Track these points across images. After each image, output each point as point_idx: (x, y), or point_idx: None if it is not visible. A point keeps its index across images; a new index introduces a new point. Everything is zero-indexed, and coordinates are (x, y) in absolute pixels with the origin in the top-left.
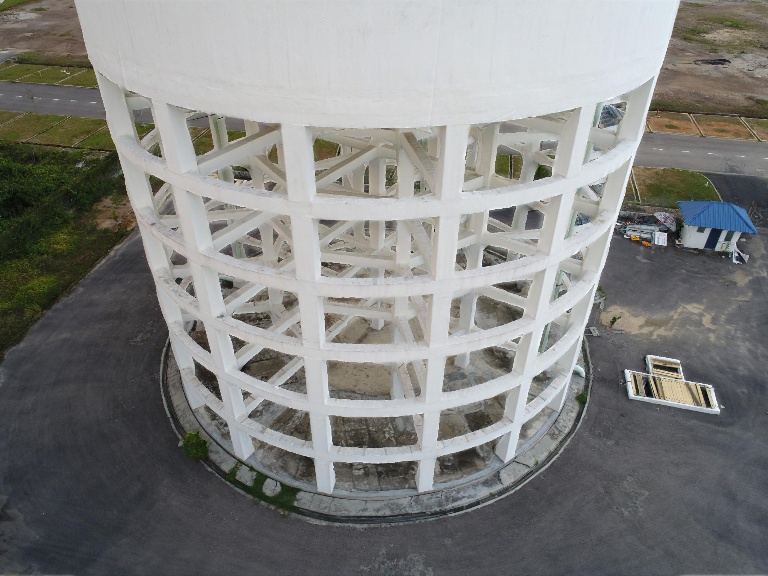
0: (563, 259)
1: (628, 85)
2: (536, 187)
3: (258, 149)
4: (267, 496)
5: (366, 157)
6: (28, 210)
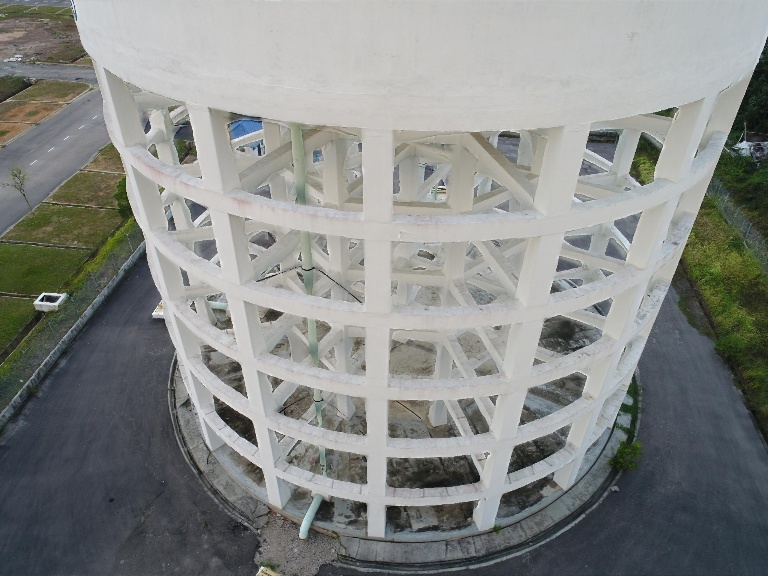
0: None
1: None
2: None
3: None
4: None
5: None
6: None
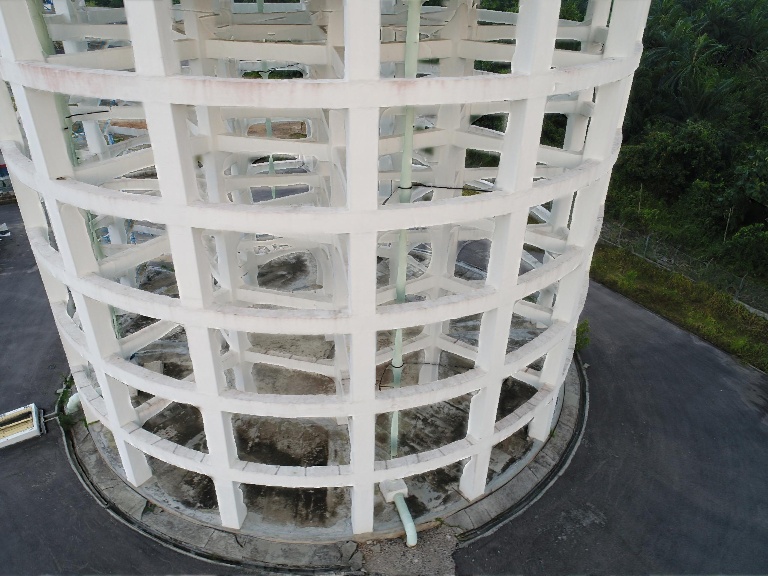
0: None
1: None
2: None
3: None
4: None
5: None
6: None
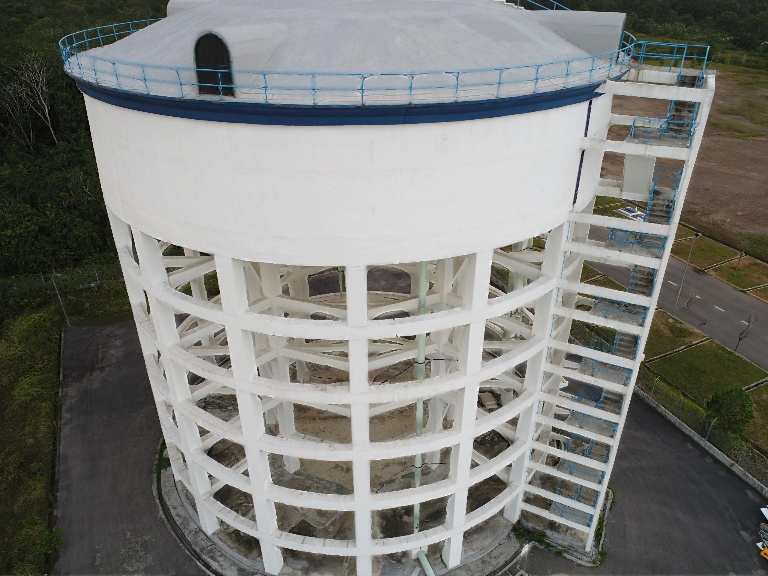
0: (255, 392)
1: (274, 257)
2: (196, 305)
3: None
4: (162, 454)
5: None
6: None
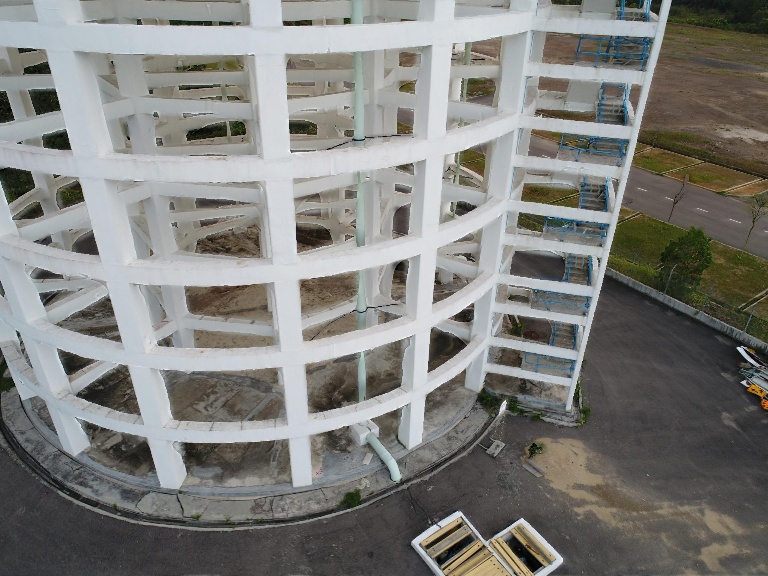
0: (111, 177)
1: None
2: None
3: (20, 1)
4: (3, 375)
5: (224, 77)
6: (196, 135)
